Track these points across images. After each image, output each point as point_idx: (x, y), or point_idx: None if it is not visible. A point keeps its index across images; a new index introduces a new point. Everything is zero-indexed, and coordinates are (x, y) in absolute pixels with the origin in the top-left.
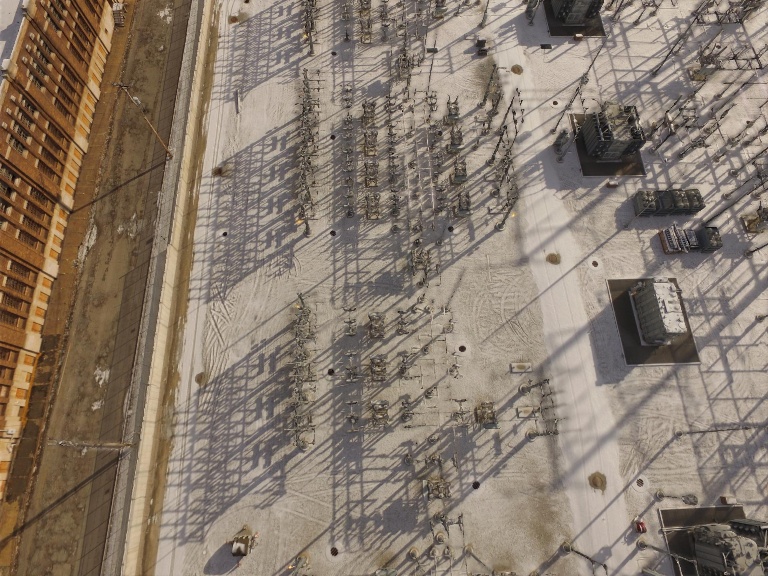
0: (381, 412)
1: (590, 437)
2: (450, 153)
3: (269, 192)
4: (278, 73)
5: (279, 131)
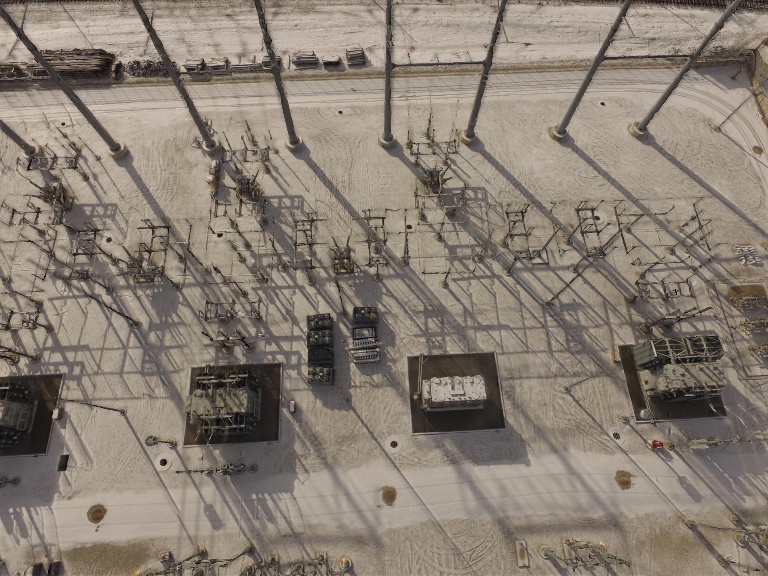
0: None
1: (584, 482)
2: None
3: None
4: None
5: None
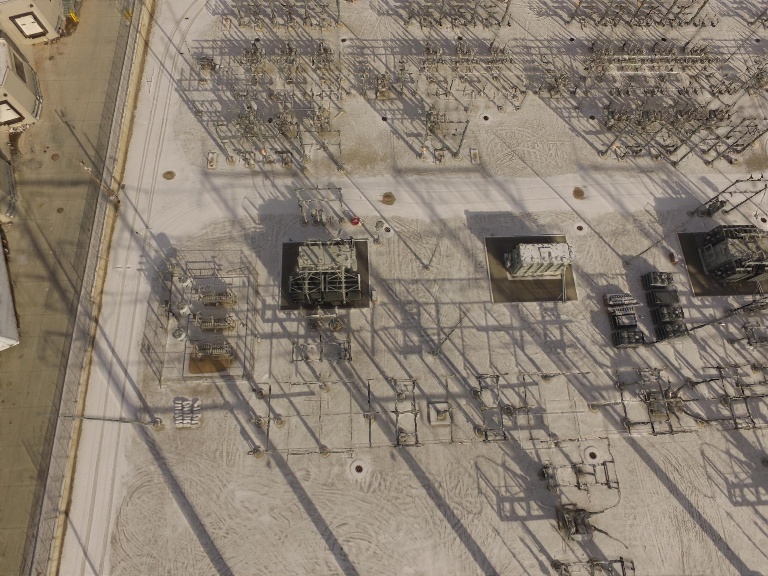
0: (435, 53)
1: (422, 198)
2: (672, 122)
3: (600, 1)
4: (720, 3)
5: (660, 5)
